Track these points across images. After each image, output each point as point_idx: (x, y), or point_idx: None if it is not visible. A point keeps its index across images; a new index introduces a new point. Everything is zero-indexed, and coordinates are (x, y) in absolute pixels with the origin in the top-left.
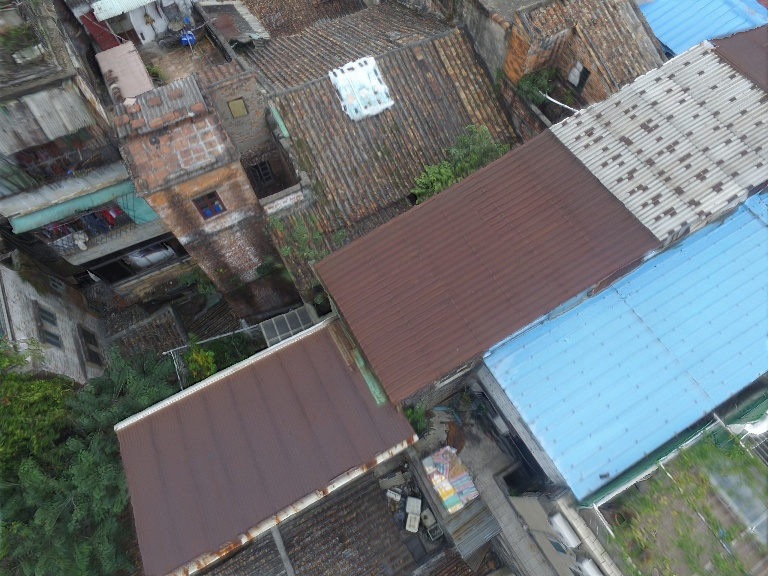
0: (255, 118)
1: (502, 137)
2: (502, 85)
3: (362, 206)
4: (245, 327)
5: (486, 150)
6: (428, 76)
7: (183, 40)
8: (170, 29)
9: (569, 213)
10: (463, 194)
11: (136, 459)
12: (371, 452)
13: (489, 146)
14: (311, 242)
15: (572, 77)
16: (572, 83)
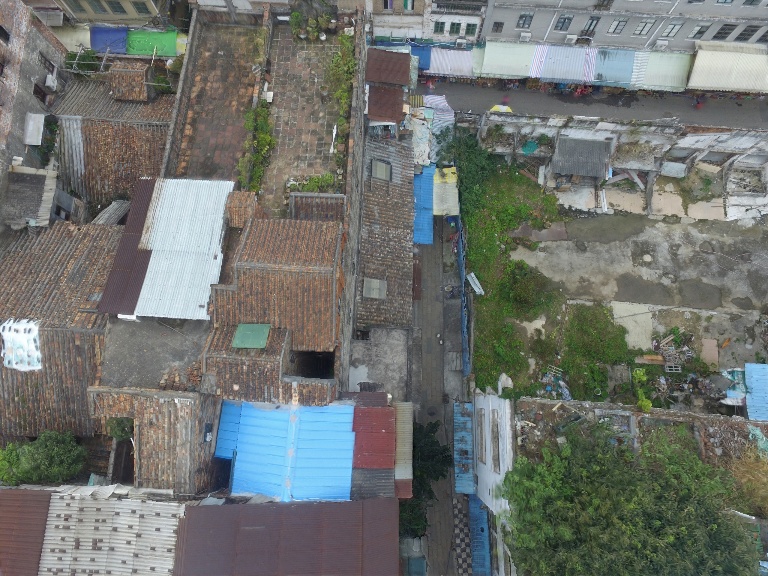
0: None
1: None
2: None
3: None
4: None
5: (35, 466)
6: (78, 359)
7: None
8: None
9: (11, 567)
10: None
11: None
12: None
13: (37, 465)
14: None
15: None
16: None
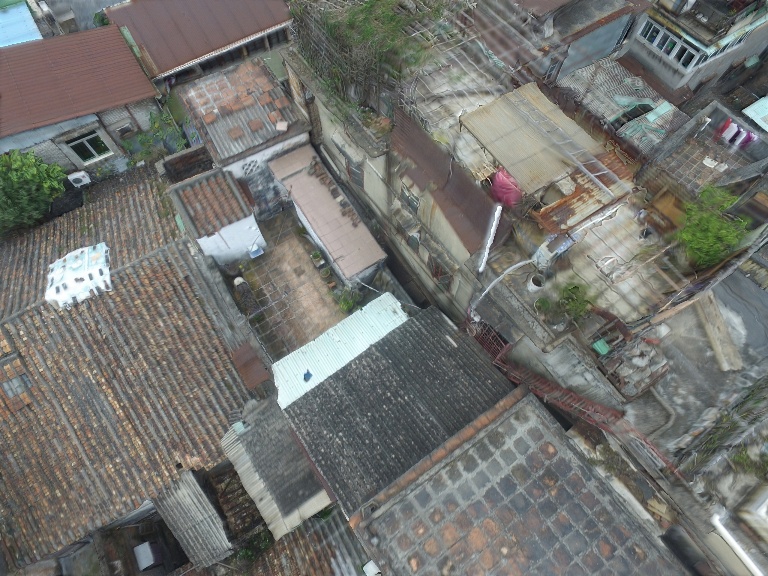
0: None
1: None
2: None
3: None
4: None
5: None
6: None
7: None
8: None
9: None
10: (4, 125)
11: (279, 4)
12: (134, 4)
13: None
14: None
15: None
16: None
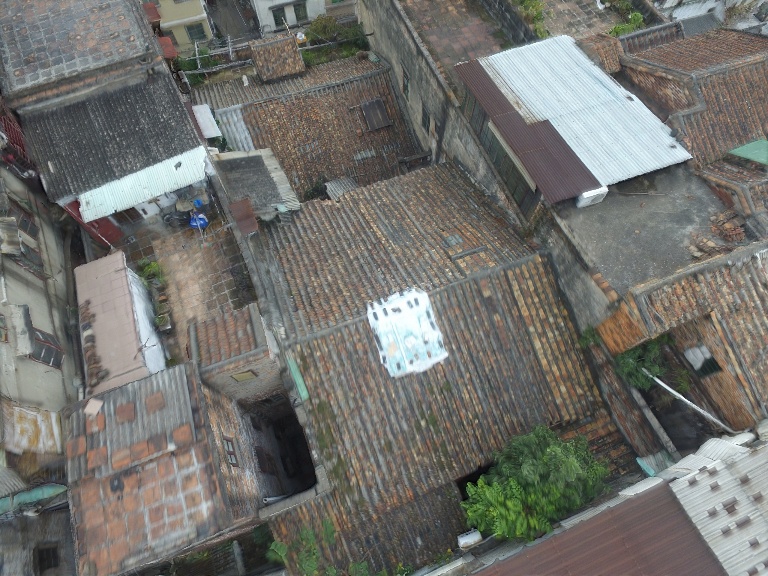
0: (267, 375)
1: (584, 401)
2: (592, 341)
3: (394, 493)
4: (237, 551)
5: None
6: (495, 319)
7: (192, 224)
8: (177, 212)
9: None
10: (539, 572)
11: None
12: None
13: (576, 473)
14: (323, 539)
15: (691, 355)
16: (690, 362)
